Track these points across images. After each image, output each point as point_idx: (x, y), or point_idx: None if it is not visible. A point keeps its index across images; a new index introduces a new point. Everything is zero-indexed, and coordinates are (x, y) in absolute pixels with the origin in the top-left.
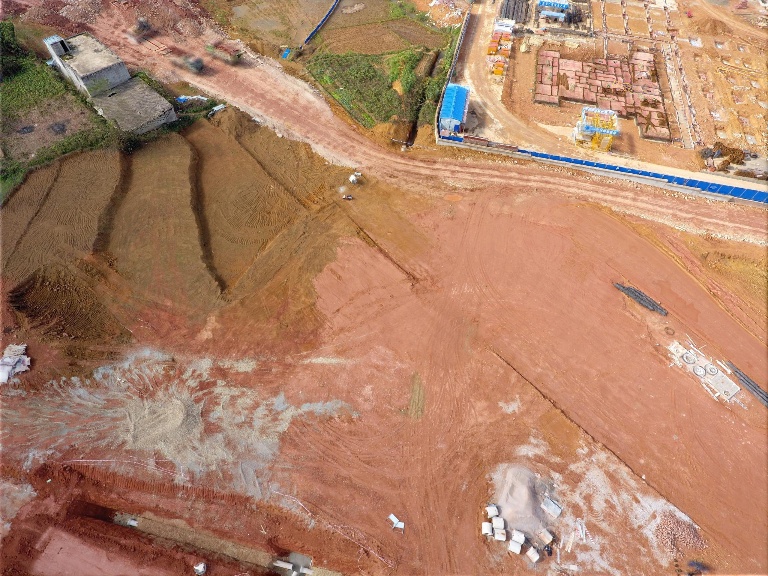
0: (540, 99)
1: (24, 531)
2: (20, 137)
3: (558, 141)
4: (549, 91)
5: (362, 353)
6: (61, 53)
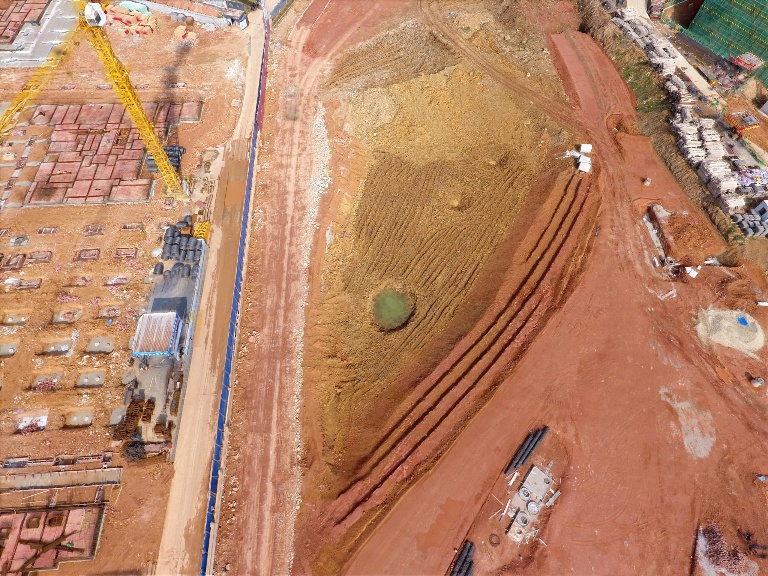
0: None
1: None
2: None
3: None
4: None
5: None
6: None
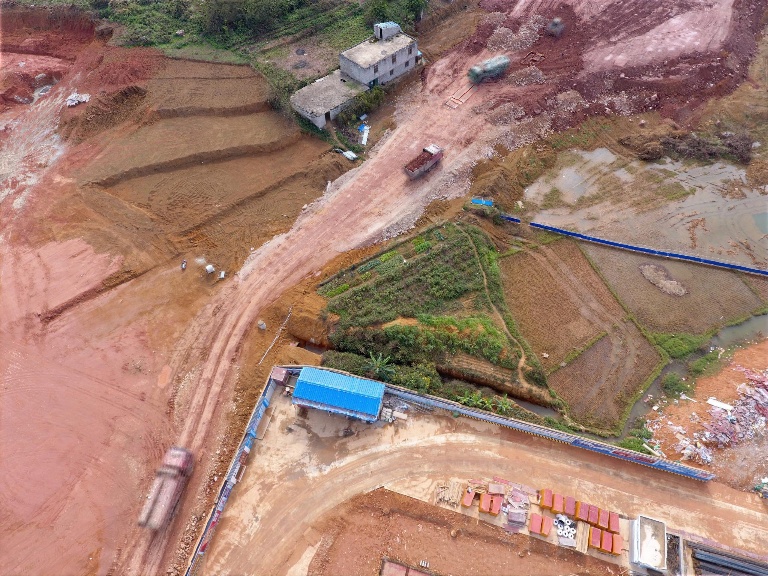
0: (387, 573)
1: None
2: (291, 51)
3: None
4: None
5: None
6: (378, 36)
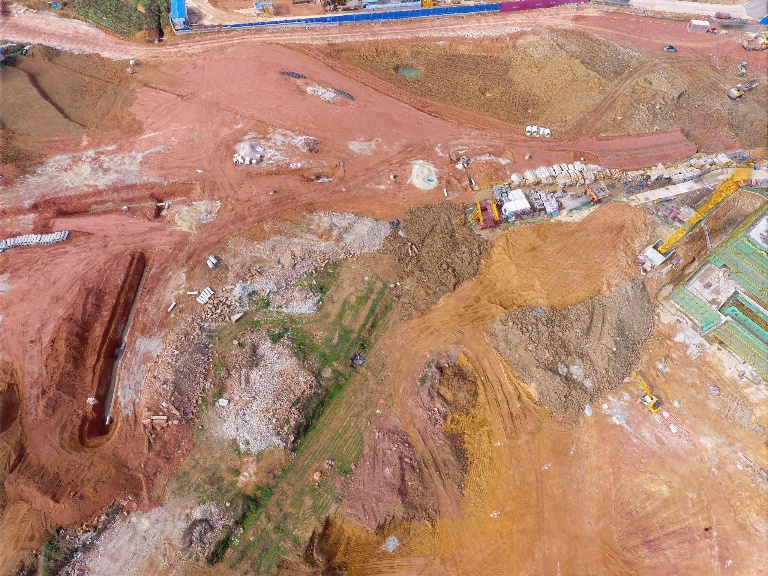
0: None
1: None
2: None
3: (246, 17)
4: None
5: (166, 128)
6: None
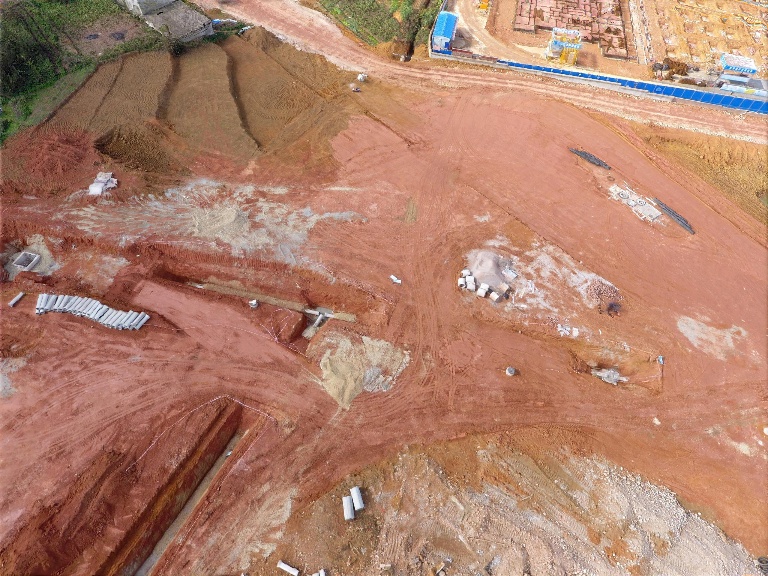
0: (519, 27)
1: (124, 281)
2: (88, 41)
3: (532, 57)
4: (527, 21)
5: (369, 185)
6: None
